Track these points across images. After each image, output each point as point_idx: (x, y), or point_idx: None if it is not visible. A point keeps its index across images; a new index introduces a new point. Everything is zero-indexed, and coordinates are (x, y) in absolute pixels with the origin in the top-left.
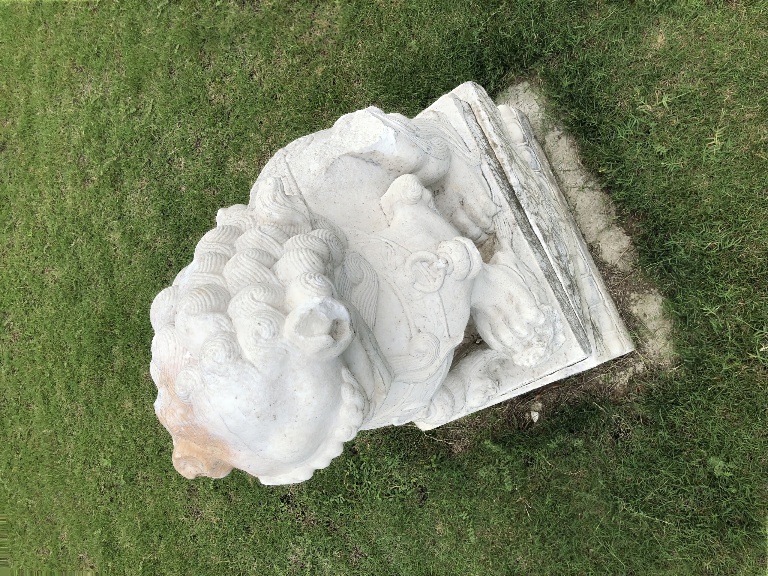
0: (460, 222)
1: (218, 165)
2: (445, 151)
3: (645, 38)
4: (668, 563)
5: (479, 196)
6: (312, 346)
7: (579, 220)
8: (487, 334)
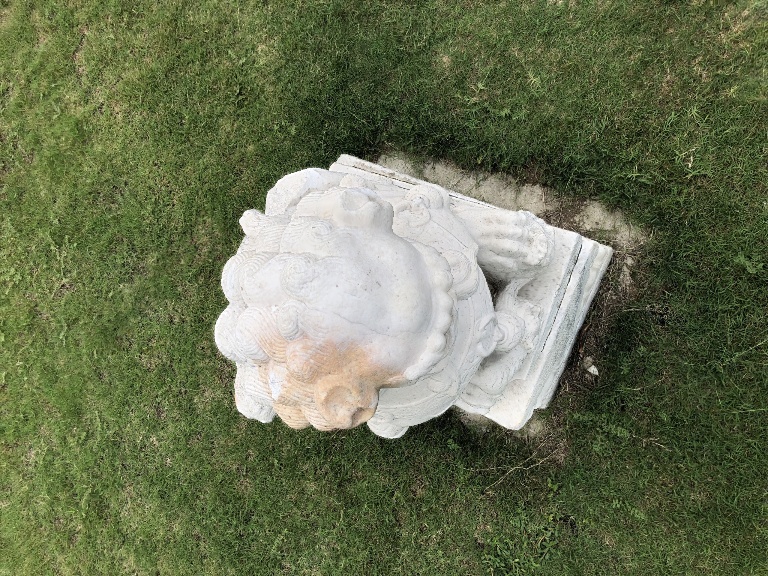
0: None
1: (187, 412)
2: None
3: (435, 66)
4: None
5: None
6: (366, 214)
7: None
8: (495, 260)
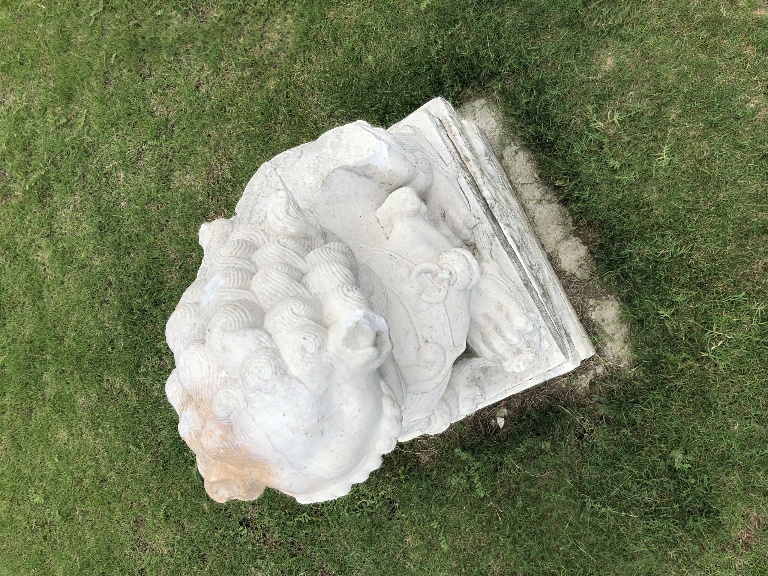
0: None
1: (162, 179)
2: (429, 165)
3: (595, 60)
4: (635, 554)
5: (460, 209)
6: (359, 359)
7: (538, 231)
8: (478, 343)
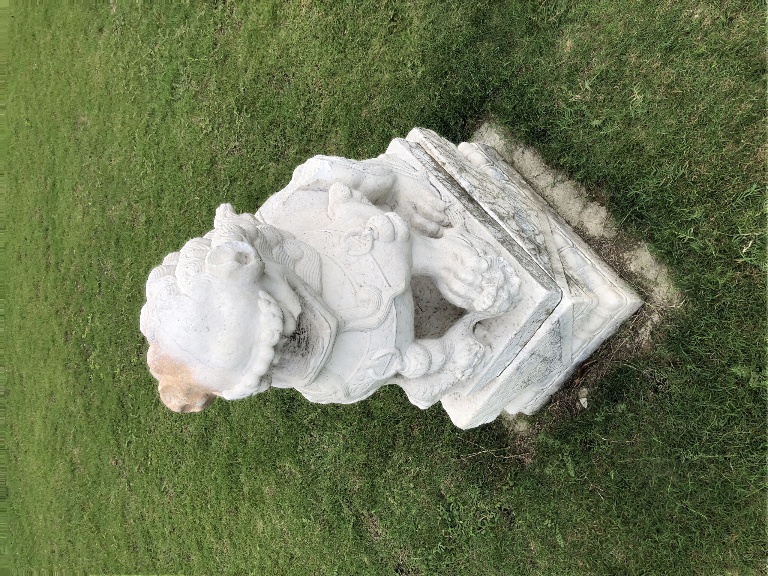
0: (417, 223)
1: None
2: (386, 171)
3: (557, 48)
4: (748, 500)
5: (426, 198)
6: (223, 270)
7: (560, 211)
8: (447, 293)
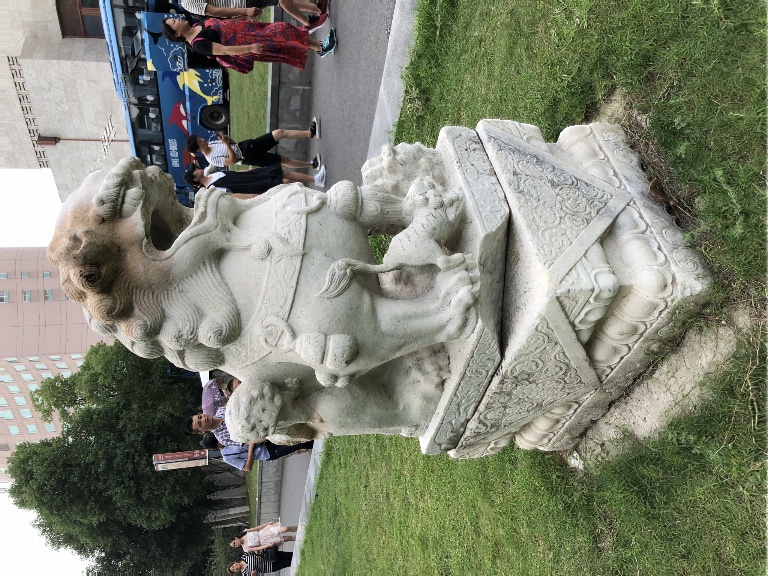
0: None
1: None
2: None
3: None
4: None
5: None
6: None
7: None
8: None
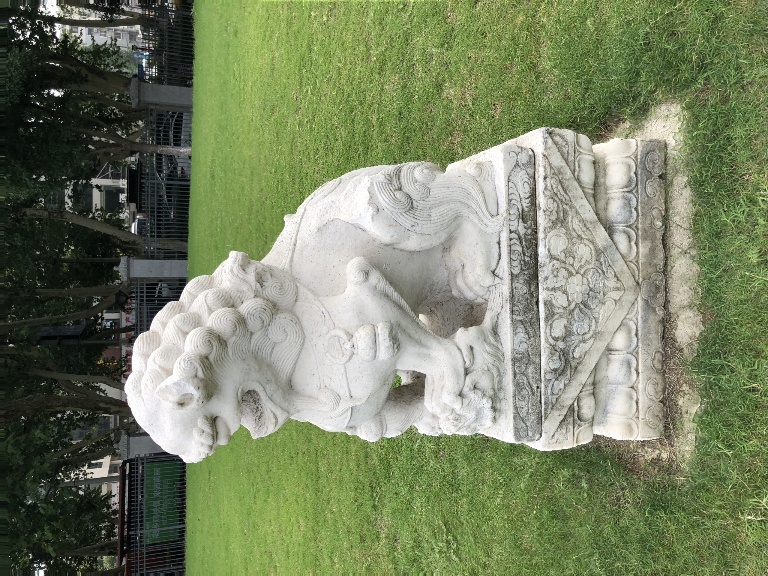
0: (457, 283)
1: (437, 87)
2: (445, 223)
3: None
4: None
5: (476, 267)
6: None
7: (670, 284)
8: None
